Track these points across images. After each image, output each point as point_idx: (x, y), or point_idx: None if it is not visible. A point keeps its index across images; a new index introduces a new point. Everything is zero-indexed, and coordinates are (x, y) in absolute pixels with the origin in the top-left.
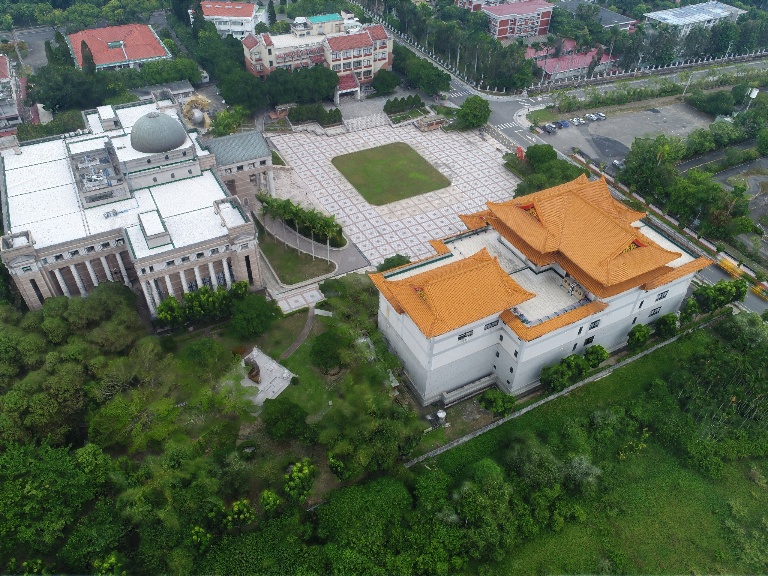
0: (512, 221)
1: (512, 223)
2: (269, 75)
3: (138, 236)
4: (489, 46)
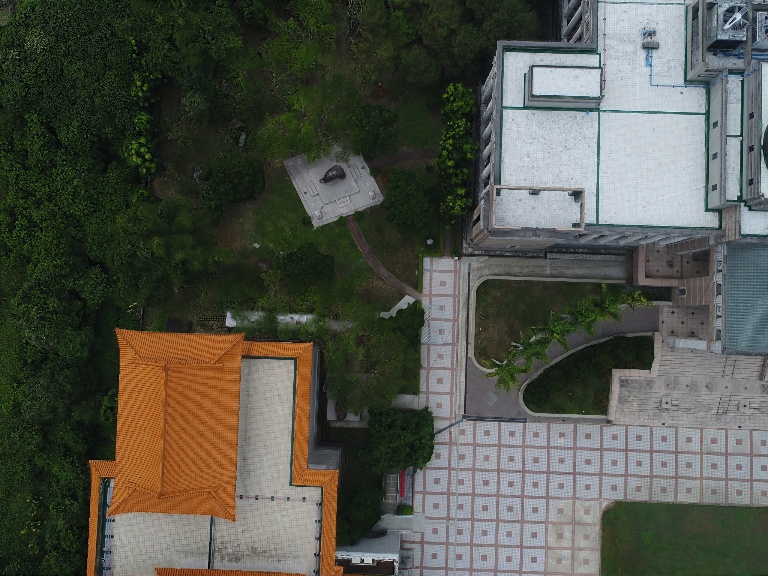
0: None
1: None
2: None
3: None
4: None
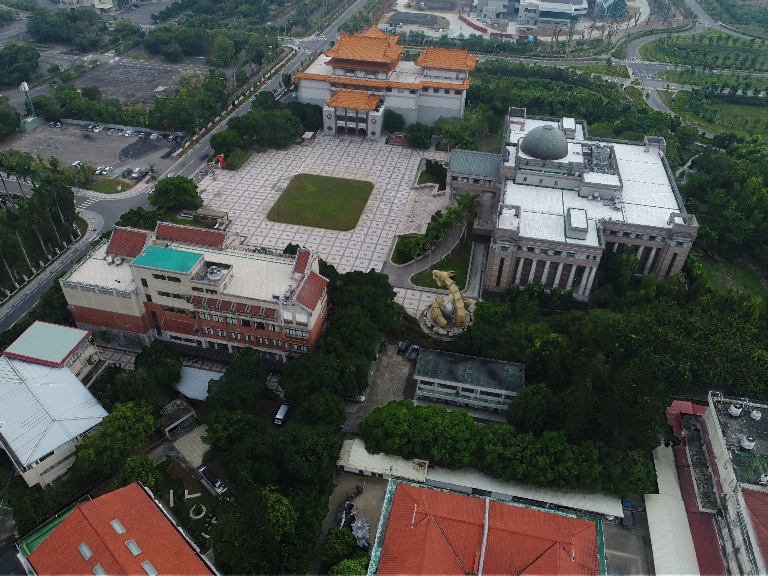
0: (394, 55)
1: (395, 55)
2: (330, 272)
3: (578, 134)
4: (54, 184)
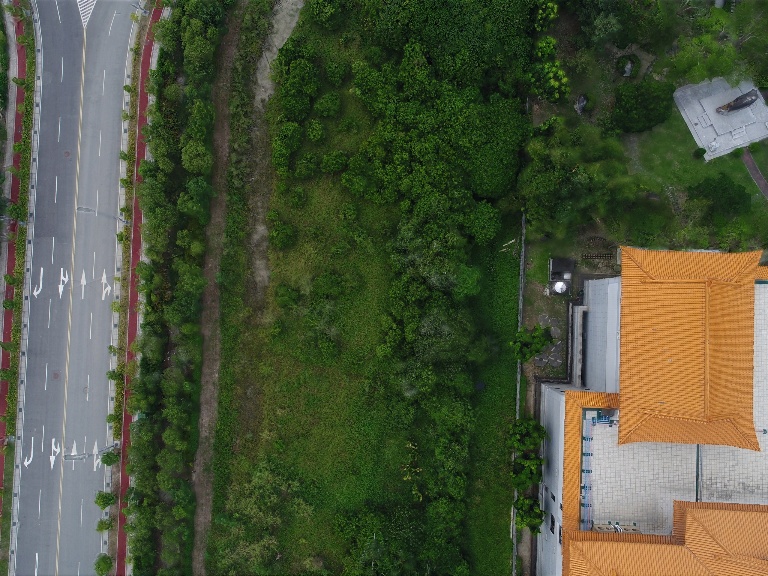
0: None
1: None
2: None
3: None
4: None
